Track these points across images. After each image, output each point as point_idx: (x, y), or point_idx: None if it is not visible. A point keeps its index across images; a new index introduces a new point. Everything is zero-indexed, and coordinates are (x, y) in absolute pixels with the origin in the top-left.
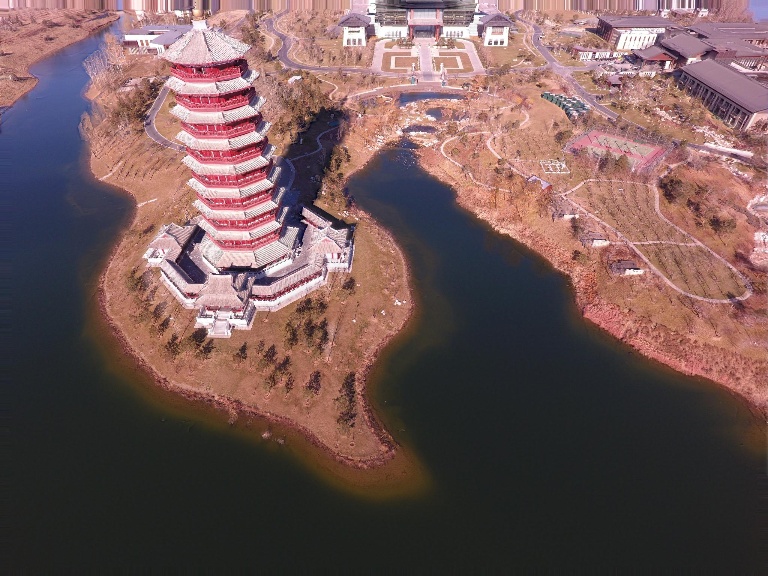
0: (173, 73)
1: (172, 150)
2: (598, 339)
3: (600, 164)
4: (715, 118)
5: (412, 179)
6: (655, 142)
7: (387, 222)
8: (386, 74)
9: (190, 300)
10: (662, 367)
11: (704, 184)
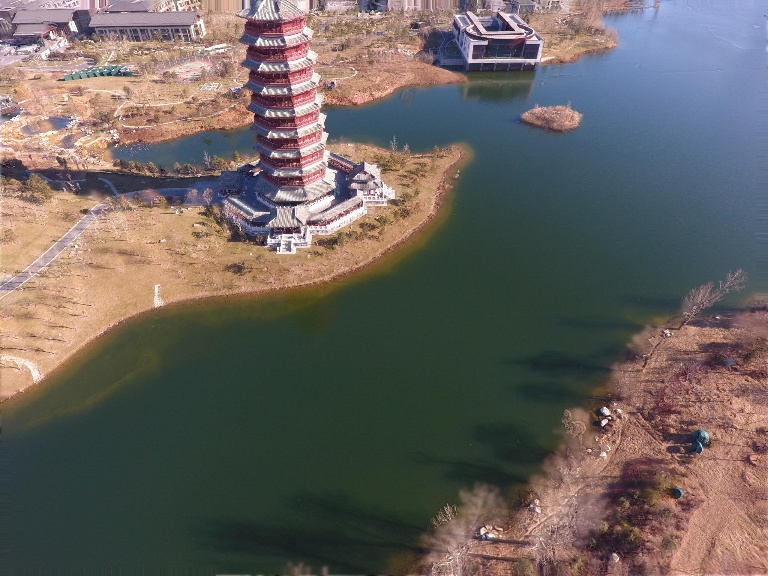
0: (286, 32)
1: (6, 298)
2: (372, 105)
3: None
4: (167, 41)
5: None
6: (194, 58)
7: (248, 155)
8: None
9: None
10: (389, 95)
11: None
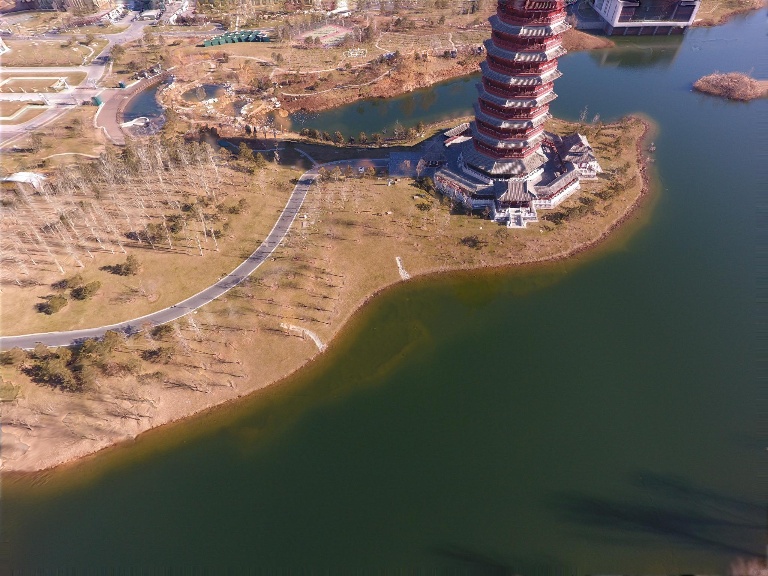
0: None
1: (262, 267)
2: None
3: None
4: (287, 5)
5: None
6: (325, 22)
7: None
8: (39, 120)
9: None
10: None
11: None
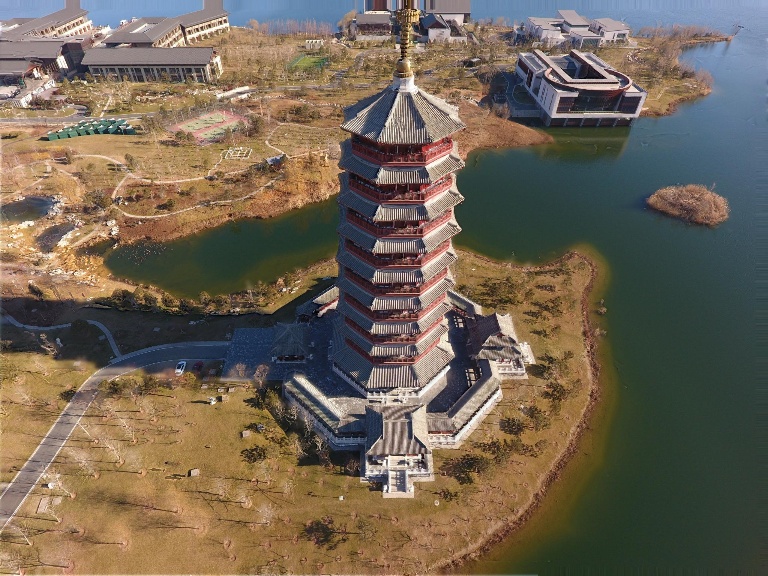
0: (430, 160)
1: None
2: None
3: None
4: (177, 83)
5: (195, 250)
6: (212, 108)
7: (298, 265)
8: None
9: None
10: None
11: (283, 109)
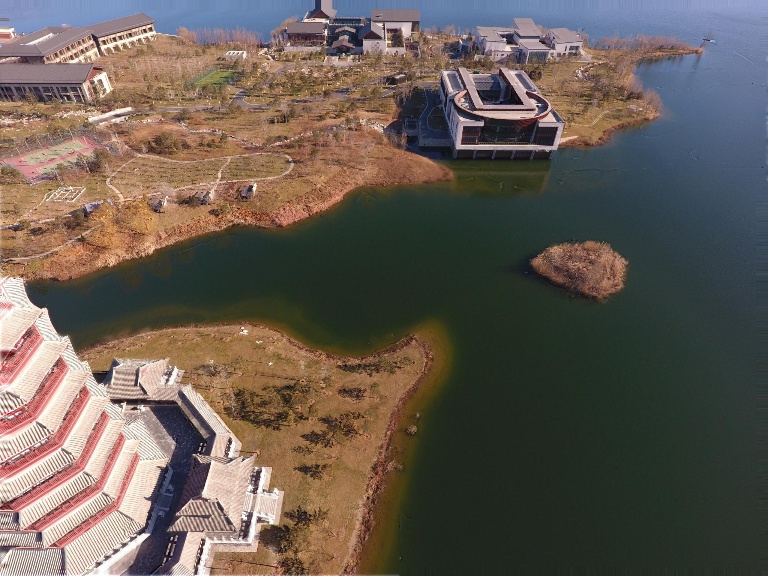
0: None
1: None
2: (306, 226)
3: (88, 168)
4: (51, 103)
5: None
6: (69, 136)
7: None
8: None
9: (199, 569)
10: (335, 207)
11: (153, 136)
